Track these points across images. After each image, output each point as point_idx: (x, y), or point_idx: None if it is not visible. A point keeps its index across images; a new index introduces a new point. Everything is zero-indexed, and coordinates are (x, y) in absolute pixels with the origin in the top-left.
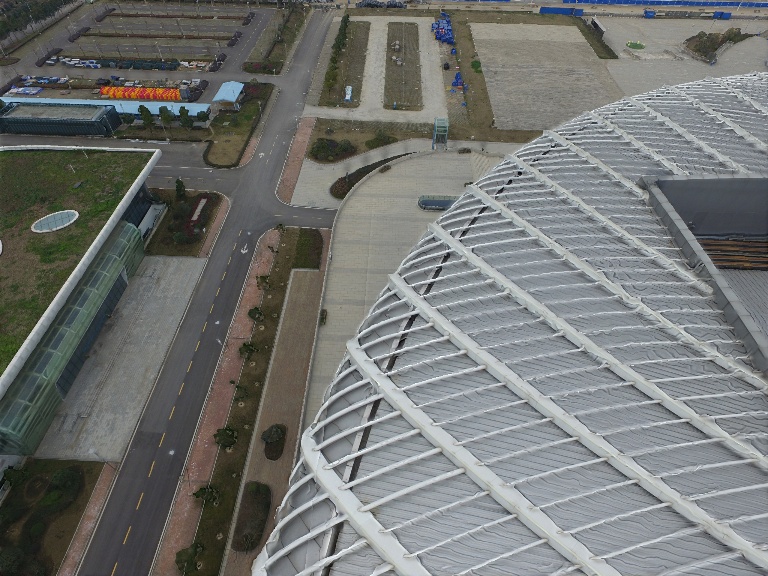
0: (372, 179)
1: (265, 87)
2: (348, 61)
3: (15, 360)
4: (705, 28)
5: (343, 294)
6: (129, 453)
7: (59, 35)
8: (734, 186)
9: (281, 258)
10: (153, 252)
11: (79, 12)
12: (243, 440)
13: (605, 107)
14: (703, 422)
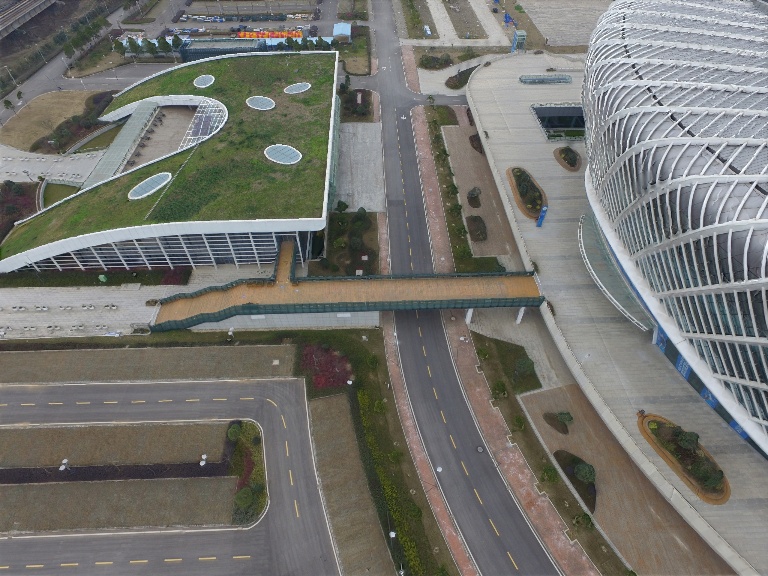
0: (481, 70)
1: (363, 28)
2: None
3: (331, 143)
4: None
5: (492, 125)
6: (388, 209)
7: (174, 2)
8: None
9: (431, 120)
10: (342, 121)
11: None
12: (454, 201)
13: None
14: (759, 26)
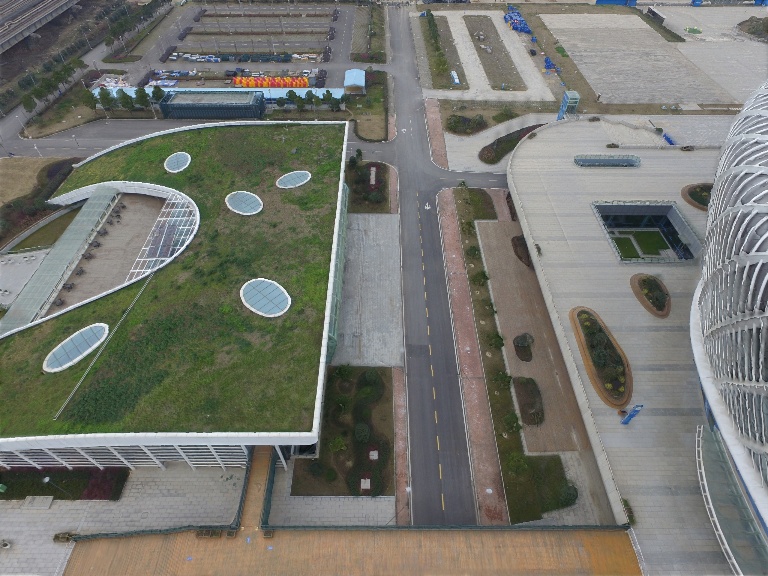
0: (524, 144)
1: (380, 74)
2: (442, 50)
3: (332, 279)
4: (751, 14)
5: (545, 233)
6: (408, 360)
7: (166, 34)
8: None
9: (462, 212)
10: (350, 210)
11: (174, 14)
12: None
13: None
14: None
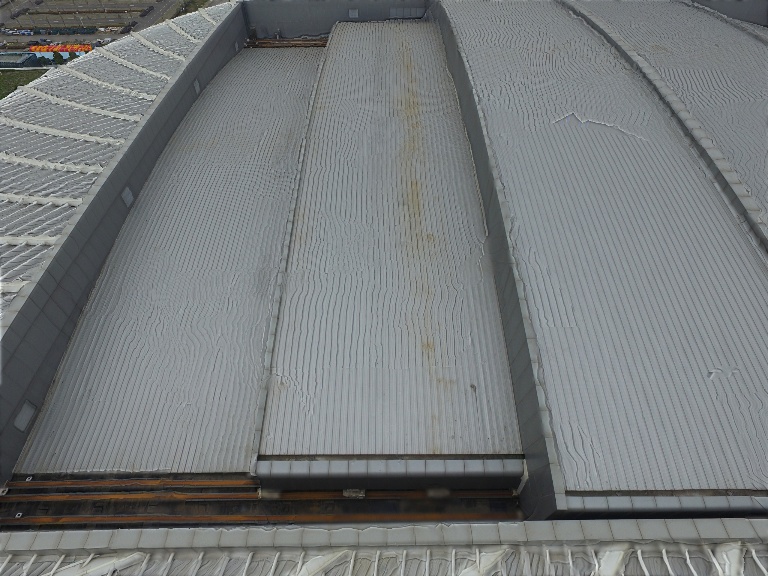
0: None
1: None
2: None
3: None
4: None
5: None
6: None
7: (3, 15)
8: (283, 2)
9: None
10: None
11: None
12: None
13: None
14: None
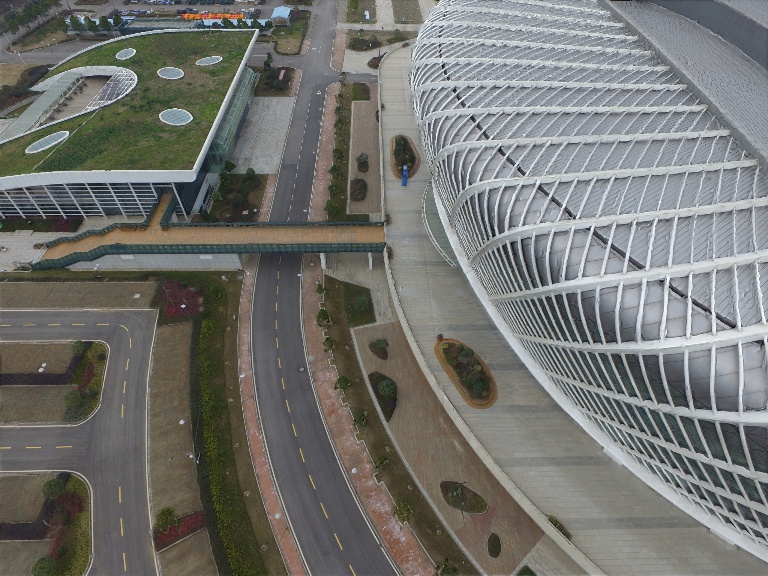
0: (398, 51)
1: (305, 12)
2: None
3: (222, 108)
4: None
5: (392, 99)
6: (281, 171)
7: None
8: None
9: (344, 96)
10: (259, 95)
11: None
12: (344, 166)
13: None
14: None
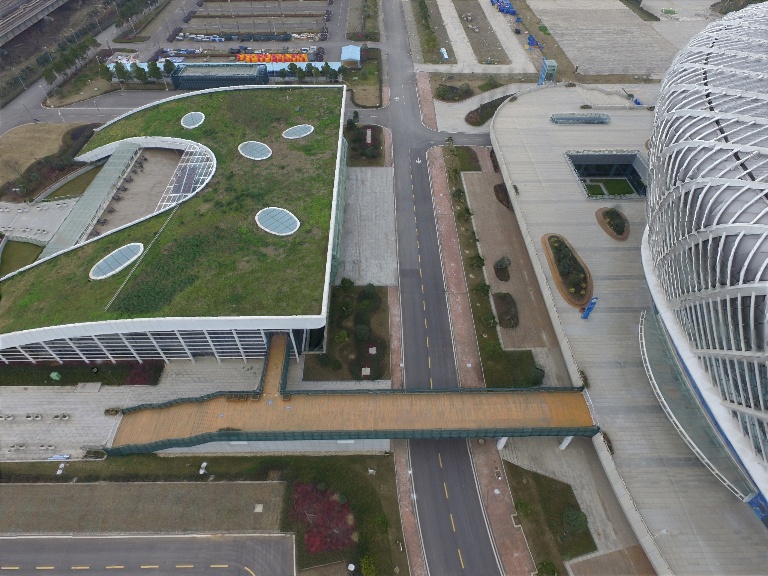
0: (506, 106)
1: (374, 51)
2: None
3: (334, 207)
4: None
5: (522, 177)
6: (401, 281)
7: (172, 18)
8: None
9: (450, 165)
10: (349, 164)
11: None
12: (478, 271)
13: (742, 10)
14: None
